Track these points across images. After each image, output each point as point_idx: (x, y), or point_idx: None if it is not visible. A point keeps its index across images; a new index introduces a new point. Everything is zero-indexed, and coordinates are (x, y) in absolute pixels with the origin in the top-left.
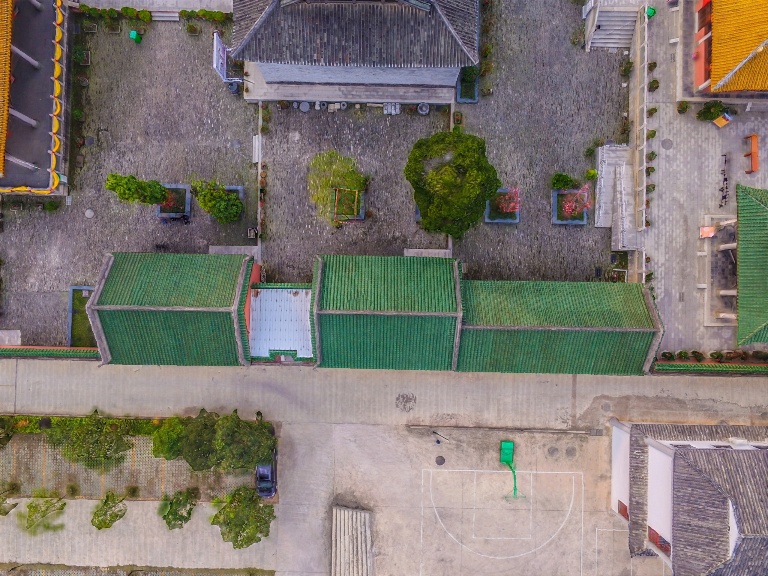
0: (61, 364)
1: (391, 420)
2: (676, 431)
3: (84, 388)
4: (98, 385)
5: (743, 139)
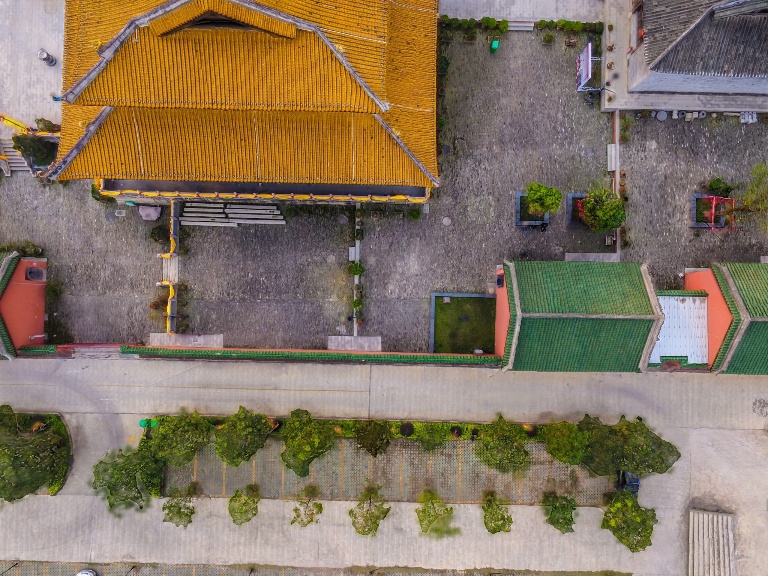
0: (415, 370)
1: (748, 425)
2: None
3: (438, 393)
4: (453, 391)
5: None
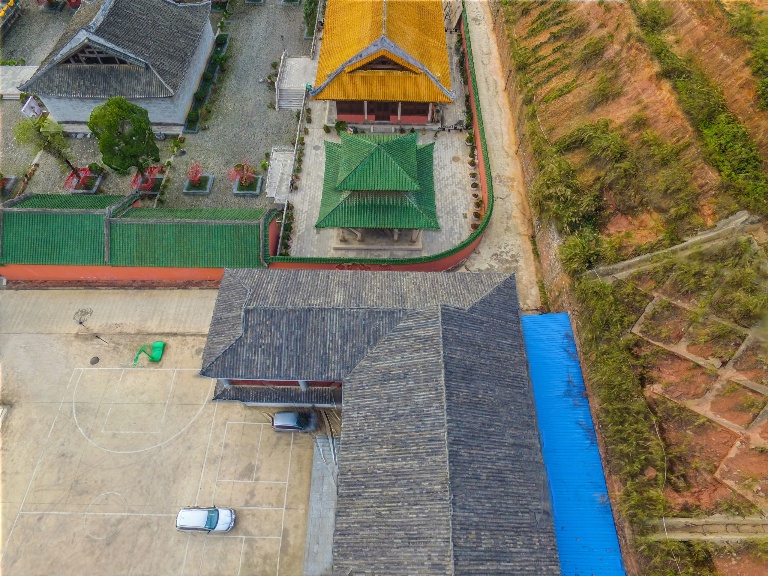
0: None
1: (64, 330)
2: None
3: None
4: None
5: None
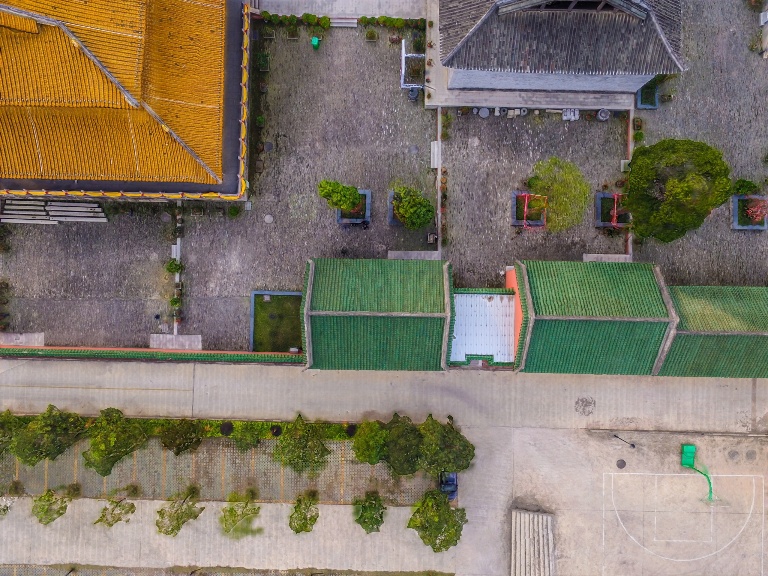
0: (239, 368)
1: (570, 424)
2: None
3: (262, 392)
4: (276, 389)
5: None
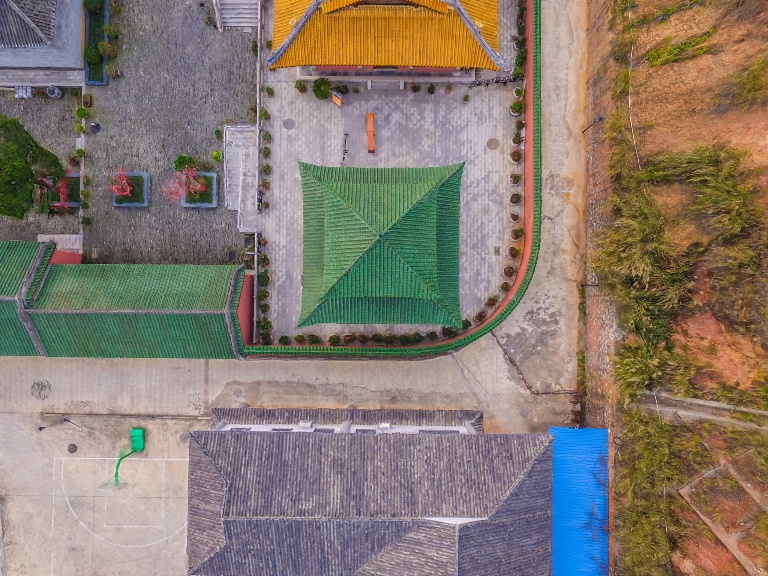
0: None
1: (26, 408)
2: (254, 415)
3: None
4: None
5: (366, 118)
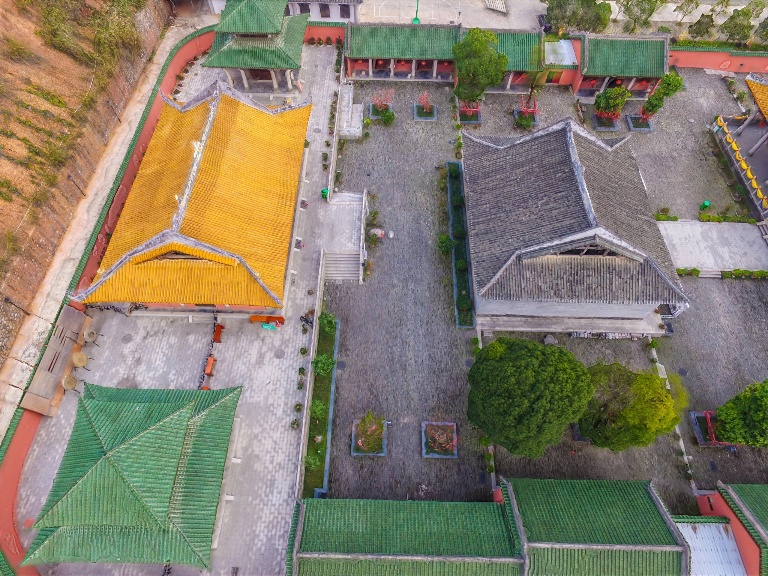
0: None
1: None
2: None
3: None
4: None
5: None
